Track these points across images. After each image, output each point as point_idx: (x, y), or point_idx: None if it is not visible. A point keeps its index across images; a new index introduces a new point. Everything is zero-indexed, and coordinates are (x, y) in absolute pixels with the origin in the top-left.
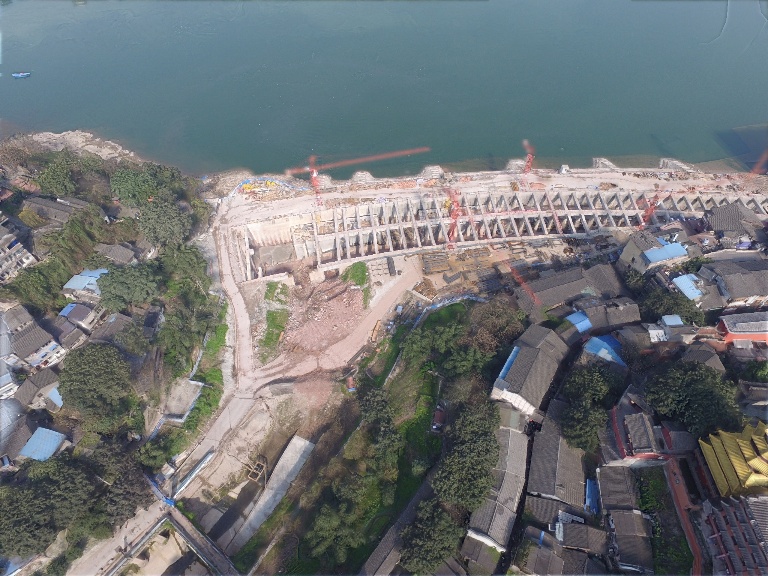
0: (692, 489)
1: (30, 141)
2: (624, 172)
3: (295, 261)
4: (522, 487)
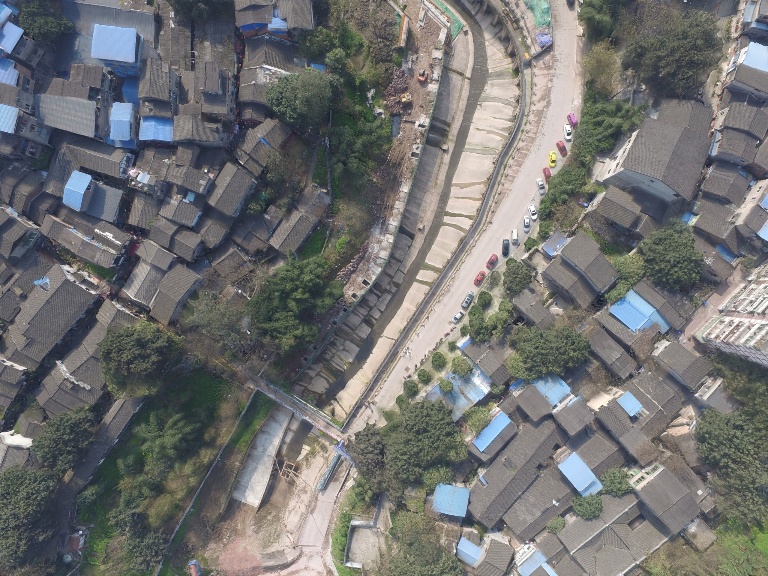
0: None
1: None
2: None
3: None
4: None
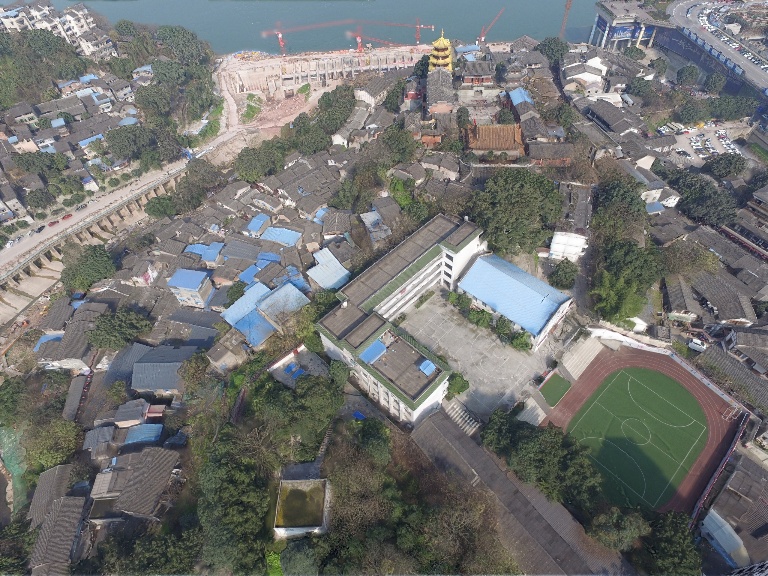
0: None
1: (104, 21)
2: None
3: (269, 97)
4: (362, 127)
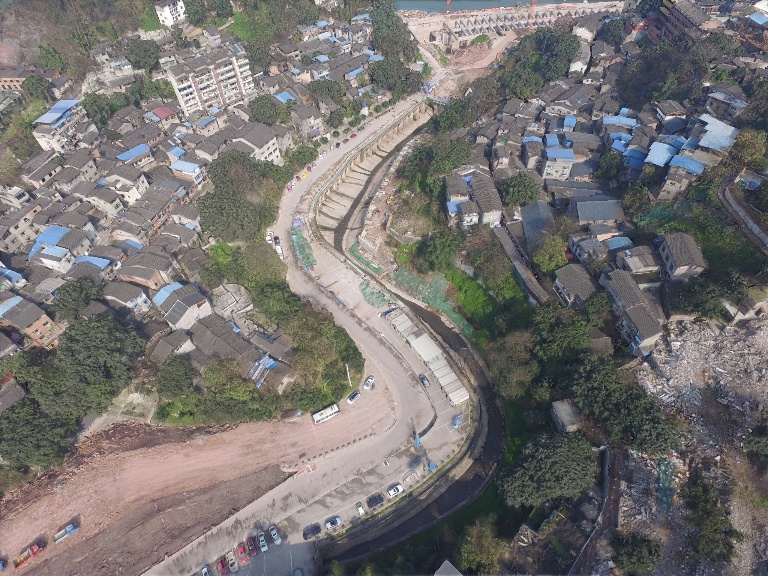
0: (658, 29)
1: None
2: (620, 1)
3: None
4: (590, 57)
